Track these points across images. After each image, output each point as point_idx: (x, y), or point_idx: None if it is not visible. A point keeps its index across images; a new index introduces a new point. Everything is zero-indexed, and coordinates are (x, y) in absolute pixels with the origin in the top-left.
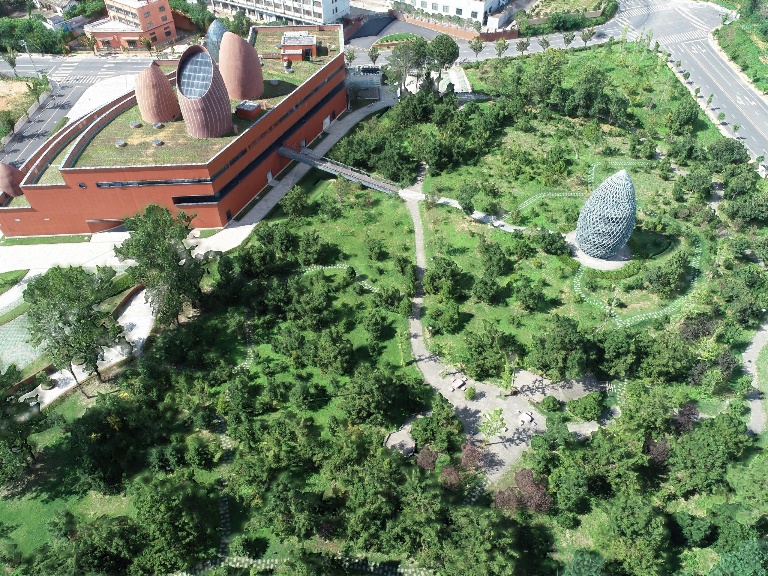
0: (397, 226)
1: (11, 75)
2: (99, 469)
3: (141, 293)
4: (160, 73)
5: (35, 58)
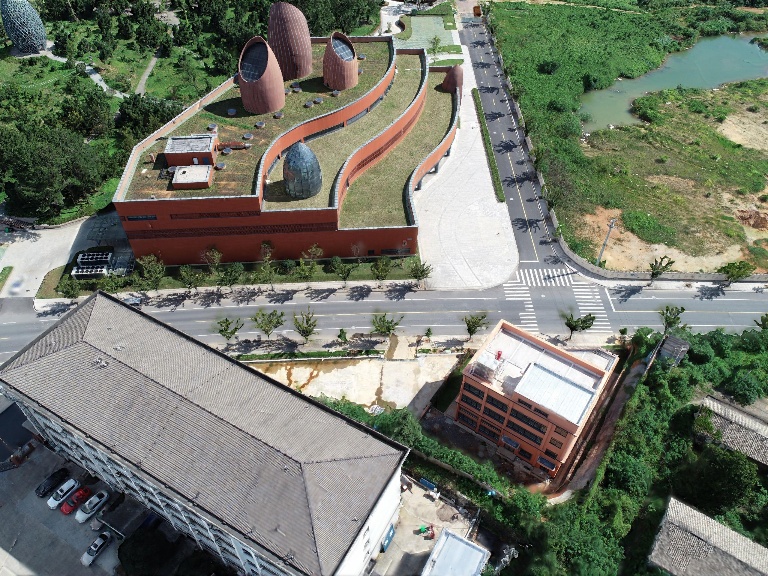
0: None
1: None
2: None
3: None
4: None
5: None
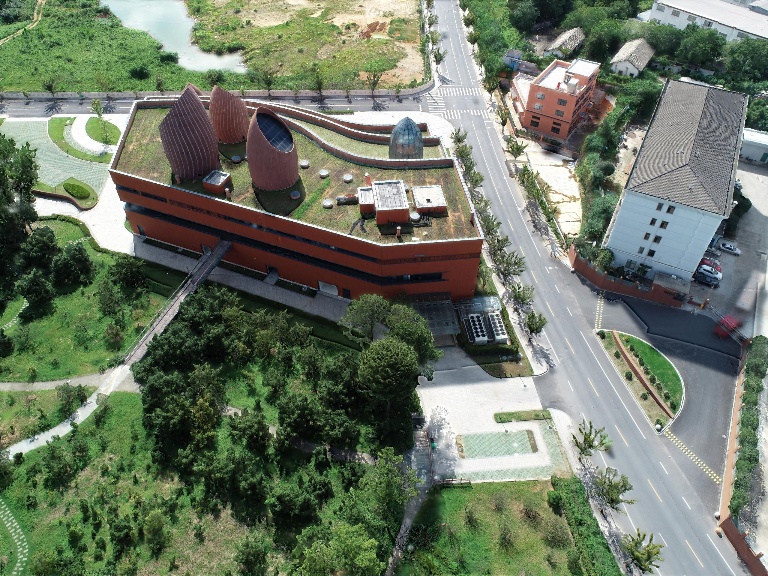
0: (51, 364)
1: None
2: None
3: (69, 204)
4: (221, 97)
5: (476, 72)
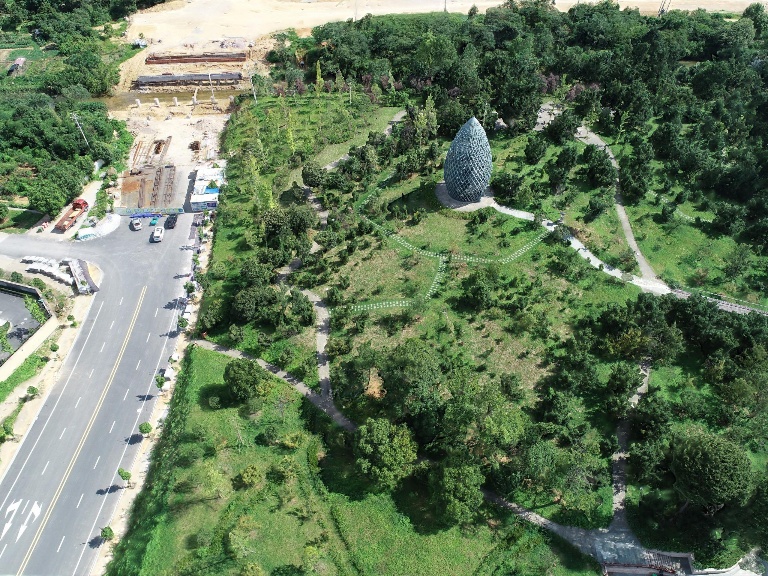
0: None
1: None
2: (764, 102)
3: None
4: None
5: None
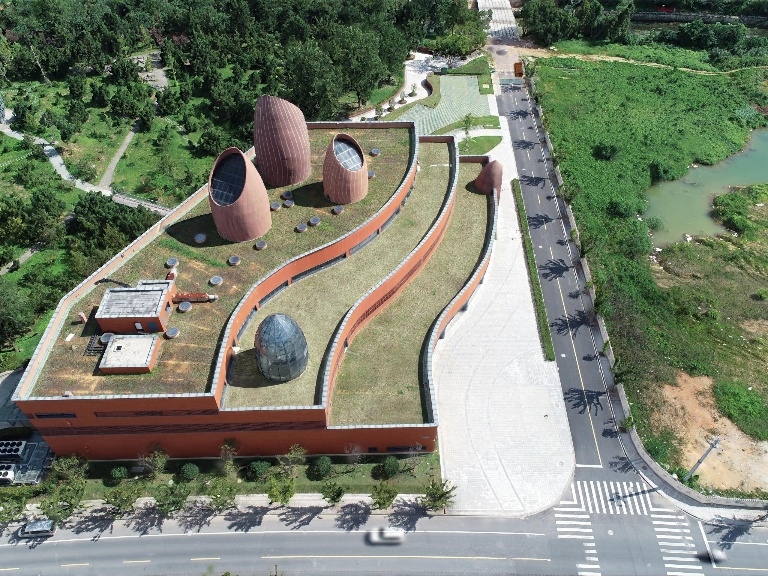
0: None
1: (765, 504)
2: None
3: None
4: None
5: None
